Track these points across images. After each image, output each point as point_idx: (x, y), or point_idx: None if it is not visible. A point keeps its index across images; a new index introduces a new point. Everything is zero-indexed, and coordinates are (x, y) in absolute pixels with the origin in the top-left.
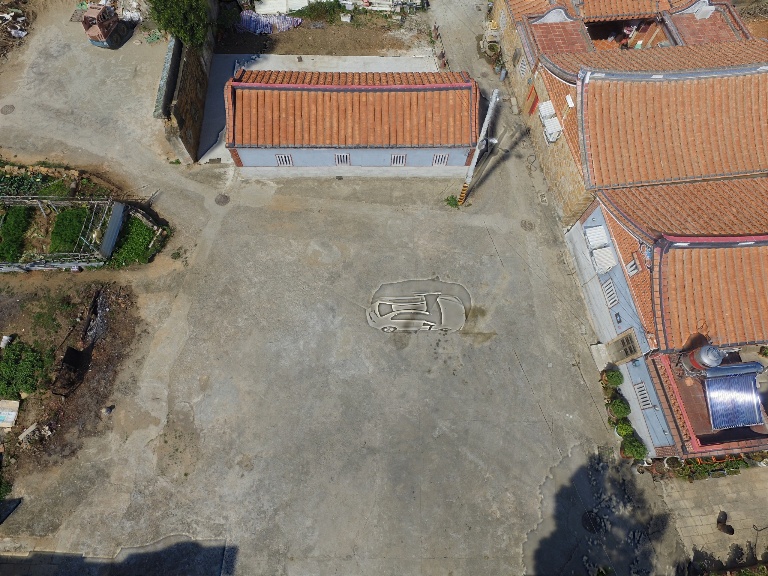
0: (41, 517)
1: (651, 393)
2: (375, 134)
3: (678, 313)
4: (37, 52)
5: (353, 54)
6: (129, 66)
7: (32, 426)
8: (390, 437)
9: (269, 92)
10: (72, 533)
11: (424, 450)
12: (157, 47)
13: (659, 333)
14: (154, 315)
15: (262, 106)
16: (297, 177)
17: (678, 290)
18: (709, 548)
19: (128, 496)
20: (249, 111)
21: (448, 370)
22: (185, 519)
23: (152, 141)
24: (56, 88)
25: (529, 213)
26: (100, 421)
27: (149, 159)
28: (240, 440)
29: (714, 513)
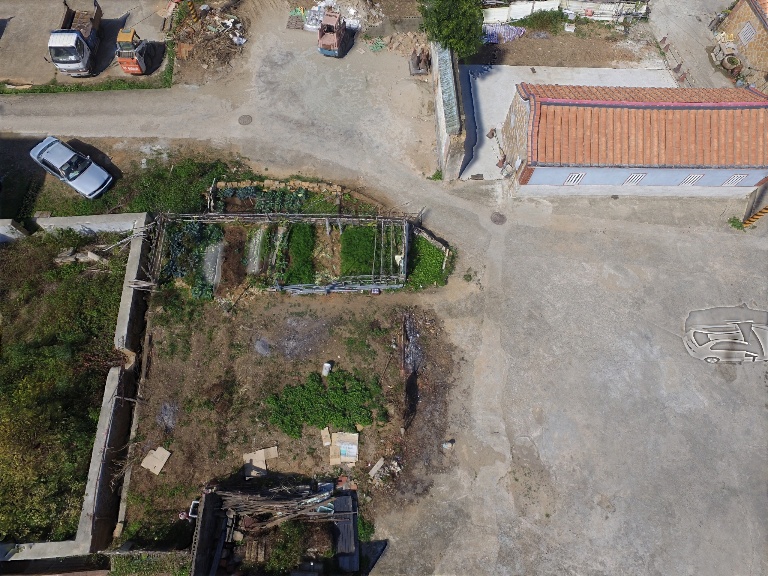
0: (412, 561)
1: None
2: (681, 153)
3: None
4: (261, 60)
5: (584, 66)
6: (359, 76)
7: (380, 461)
8: (748, 477)
9: (575, 108)
10: None
11: None
12: (382, 56)
13: None
14: (466, 342)
15: (567, 123)
16: (572, 196)
17: None
18: None
19: (496, 539)
20: (553, 128)
21: None
22: (561, 565)
23: (403, 155)
24: (290, 98)
25: None
26: (444, 456)
27: (405, 174)
28: (593, 479)
29: None
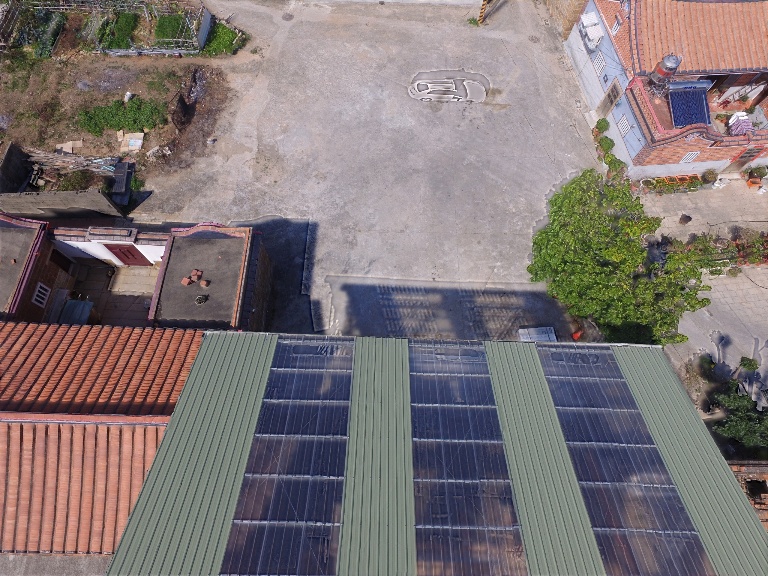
0: (168, 202)
1: (630, 117)
2: None
3: (649, 47)
4: None
5: None
6: None
7: (156, 147)
8: (430, 163)
9: None
10: (193, 212)
11: (456, 172)
12: None
13: (635, 61)
14: (241, 86)
15: None
16: (348, 2)
17: (649, 29)
18: (673, 235)
19: (233, 192)
20: None
21: (473, 125)
22: (277, 206)
23: None
24: None
25: (535, 31)
26: (206, 148)
27: None
28: (315, 163)
29: (678, 215)
